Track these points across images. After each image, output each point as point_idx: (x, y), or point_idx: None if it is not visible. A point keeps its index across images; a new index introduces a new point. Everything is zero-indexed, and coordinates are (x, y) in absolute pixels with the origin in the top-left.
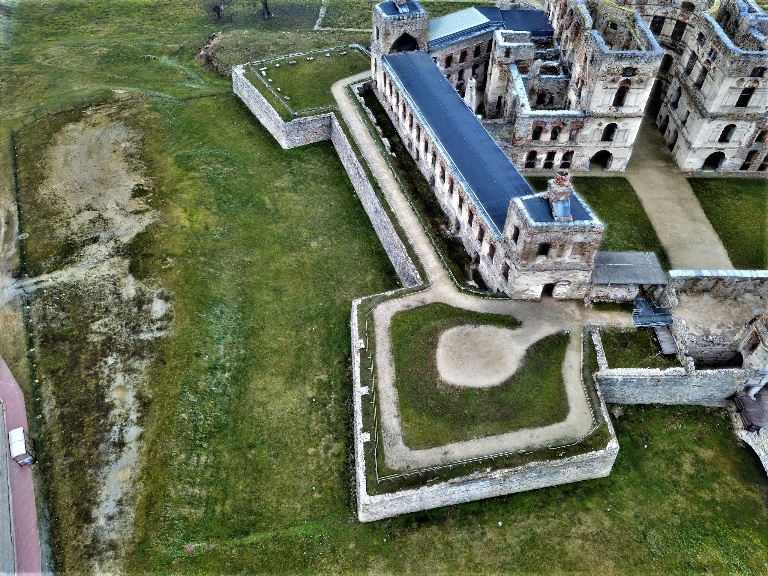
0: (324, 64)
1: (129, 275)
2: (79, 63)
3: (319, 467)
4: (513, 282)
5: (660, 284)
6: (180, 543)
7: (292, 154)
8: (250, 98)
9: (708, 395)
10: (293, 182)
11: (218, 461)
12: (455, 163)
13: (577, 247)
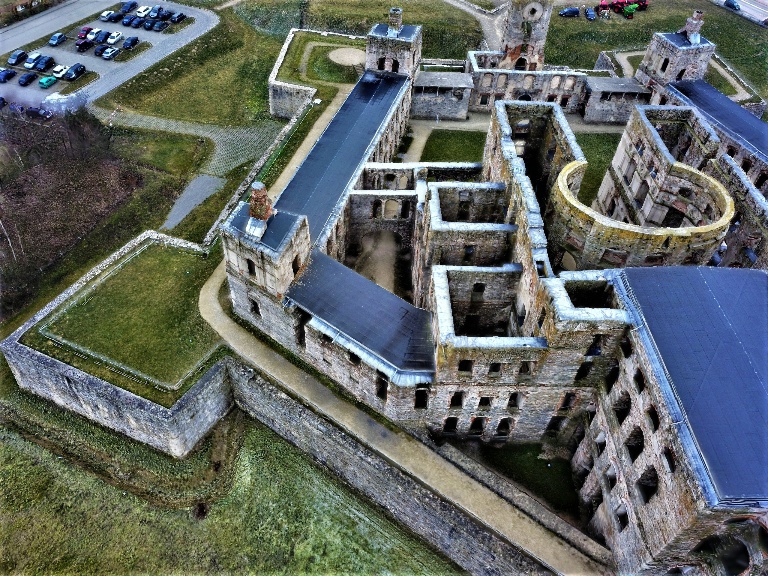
0: None
1: None
2: None
3: None
4: None
5: None
6: (766, 52)
7: None
8: None
9: None
10: None
11: None
12: None
13: None
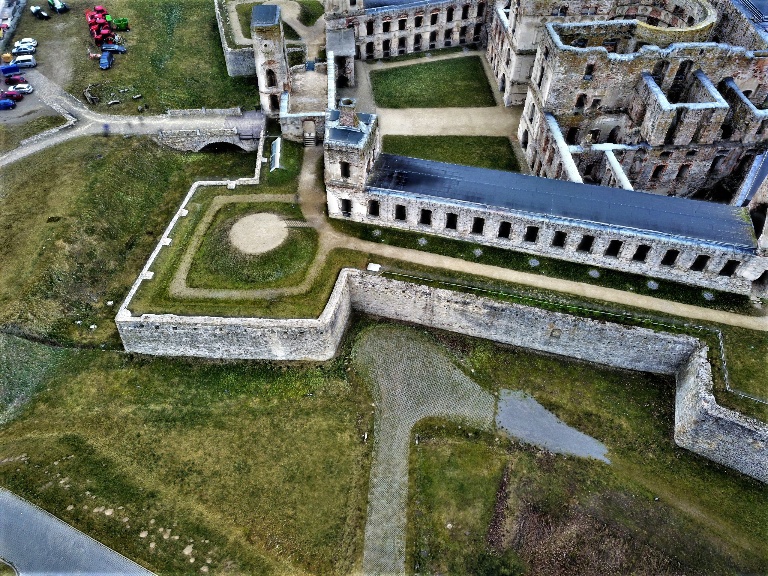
0: None
1: None
2: None
3: None
4: None
5: None
6: None
7: None
8: None
9: None
10: None
11: None
12: None
13: None
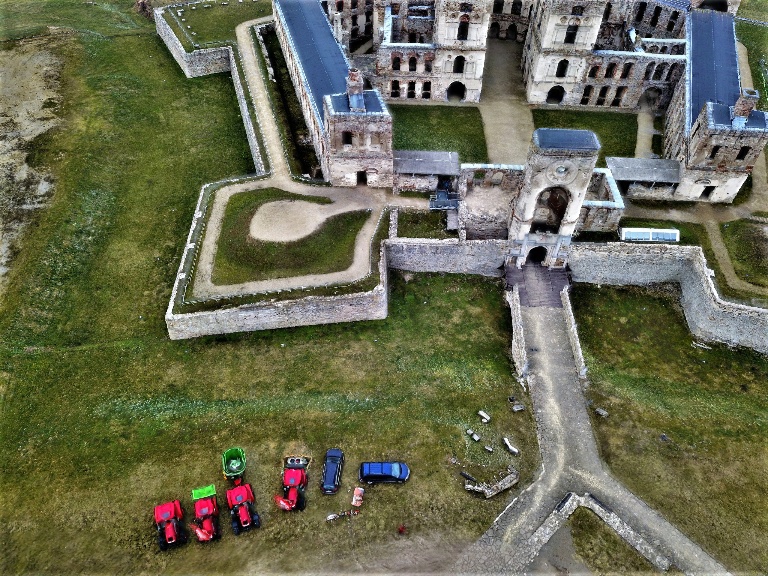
0: (235, 8)
1: (25, 164)
2: (27, 7)
3: (149, 304)
4: (331, 169)
5: (455, 176)
6: (22, 345)
7: (194, 82)
8: (166, 35)
9: (483, 264)
10: (188, 103)
11: (68, 296)
12: (307, 79)
13: (375, 137)
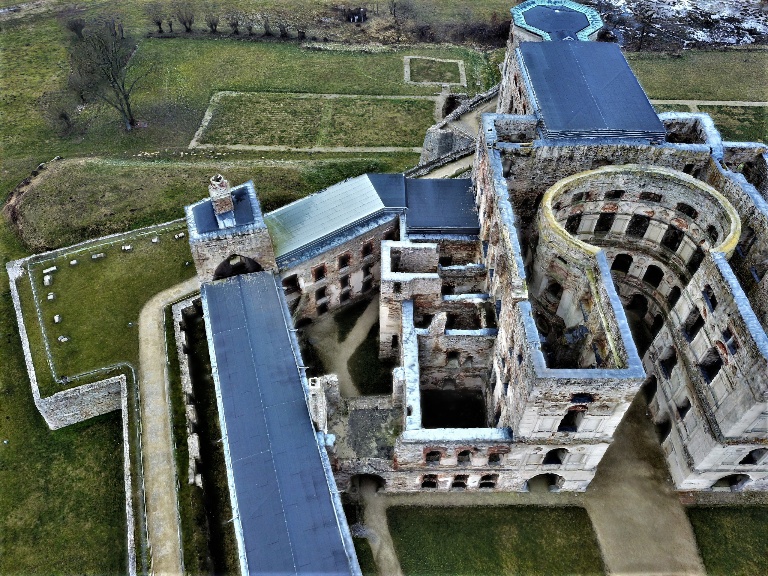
0: (144, 259)
1: None
2: None
3: None
4: None
5: None
6: None
7: (59, 442)
8: None
9: None
10: (40, 515)
11: None
12: None
13: None
